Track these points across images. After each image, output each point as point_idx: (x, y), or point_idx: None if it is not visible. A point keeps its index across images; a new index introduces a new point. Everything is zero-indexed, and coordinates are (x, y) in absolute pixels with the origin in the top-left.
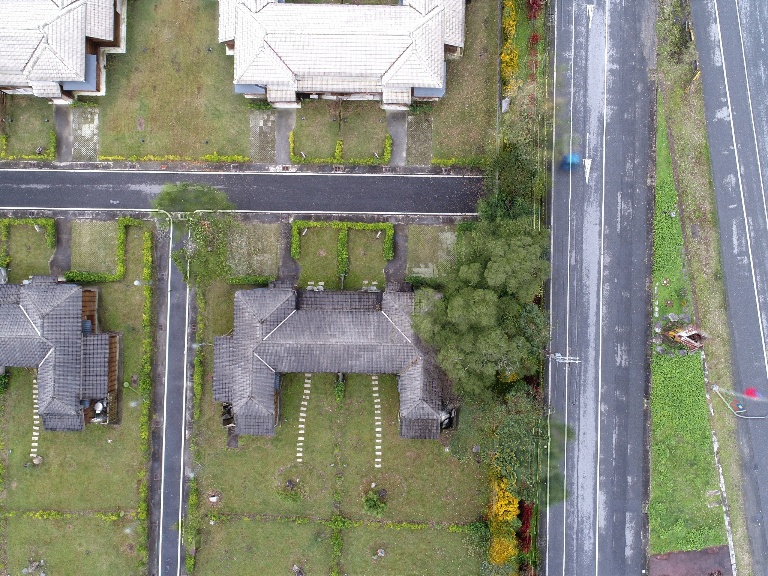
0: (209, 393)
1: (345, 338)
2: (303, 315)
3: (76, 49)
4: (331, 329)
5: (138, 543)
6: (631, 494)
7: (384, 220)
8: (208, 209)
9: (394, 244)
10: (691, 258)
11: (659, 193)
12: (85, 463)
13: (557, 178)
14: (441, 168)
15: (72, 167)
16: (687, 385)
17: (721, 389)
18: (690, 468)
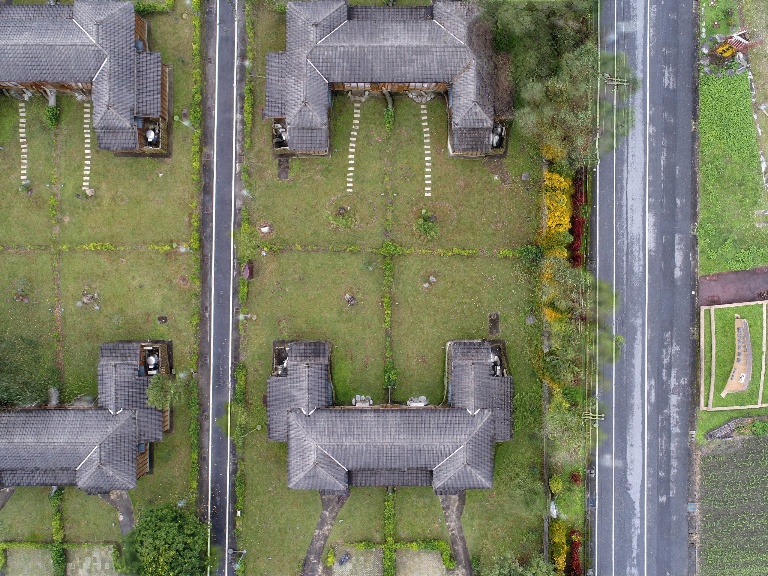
0: (259, 125)
1: (398, 41)
2: (355, 24)
3: None
4: (384, 34)
5: None
6: (680, 216)
7: None
8: None
9: None
10: None
11: None
12: (137, 197)
13: None
14: None
15: None
16: (735, 104)
17: None
18: (738, 188)
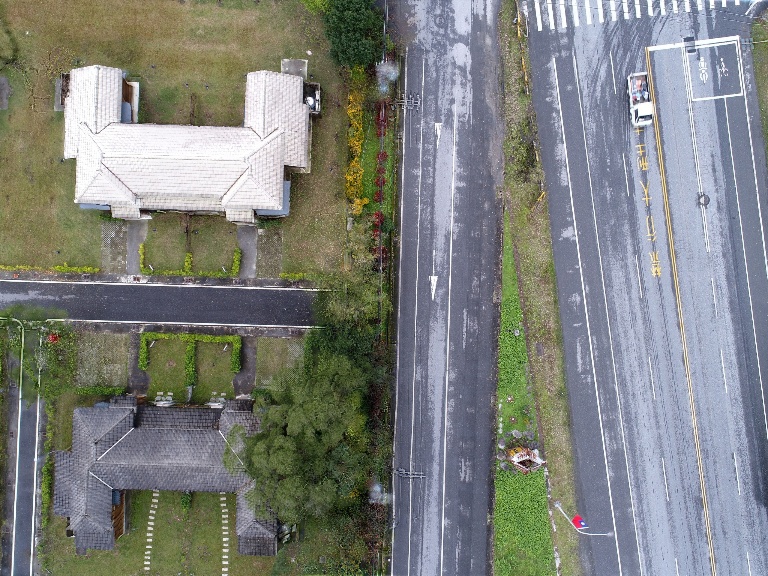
0: None
1: (178, 459)
2: (140, 434)
3: None
4: (166, 449)
5: None
6: None
7: (233, 332)
8: (59, 318)
9: (241, 357)
10: (535, 376)
11: (504, 311)
12: None
13: (404, 294)
14: (290, 281)
15: None
16: (529, 502)
17: (564, 506)
18: None
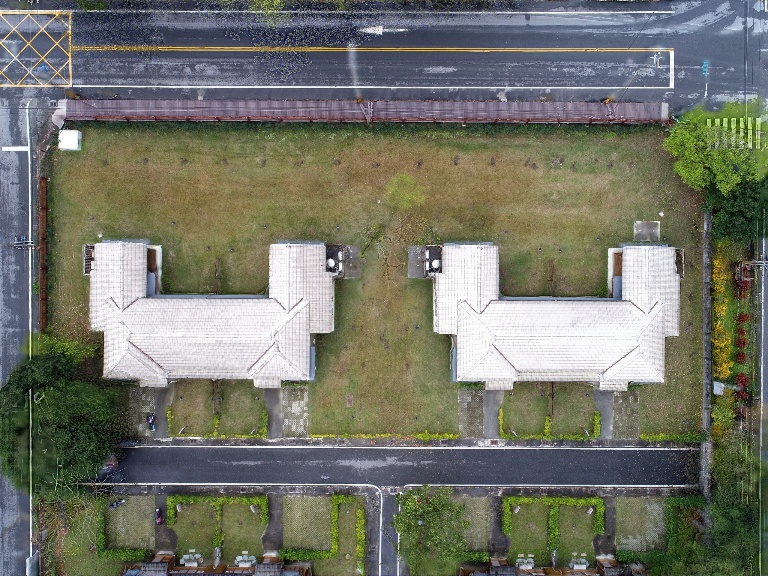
0: None
1: None
2: None
3: (302, 350)
4: None
5: None
6: None
7: (592, 492)
8: (418, 483)
9: None
10: None
11: None
12: None
13: (765, 452)
14: None
15: (282, 443)
16: None
17: None
18: None
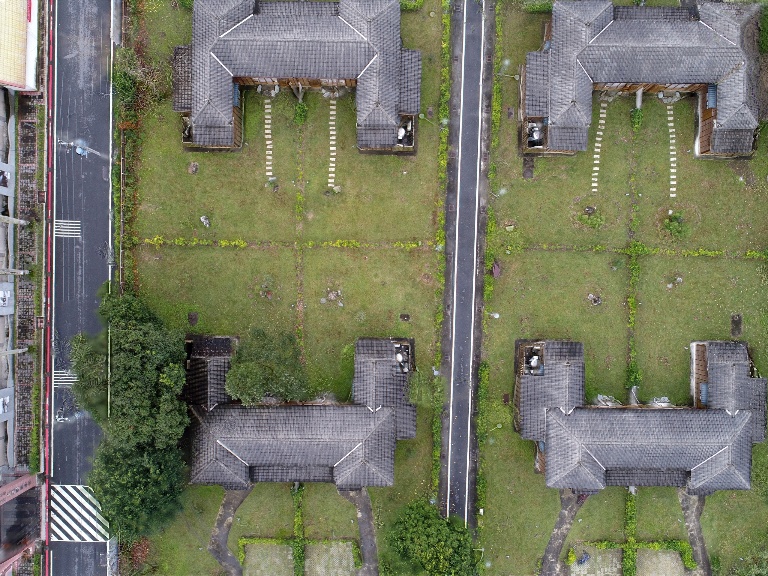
0: (505, 124)
1: (670, 41)
2: (622, 24)
3: None
4: (654, 35)
5: (434, 273)
6: None
7: None
8: None
9: None
10: None
11: None
12: (381, 195)
13: None
14: None
15: None
16: None
17: None
18: None
